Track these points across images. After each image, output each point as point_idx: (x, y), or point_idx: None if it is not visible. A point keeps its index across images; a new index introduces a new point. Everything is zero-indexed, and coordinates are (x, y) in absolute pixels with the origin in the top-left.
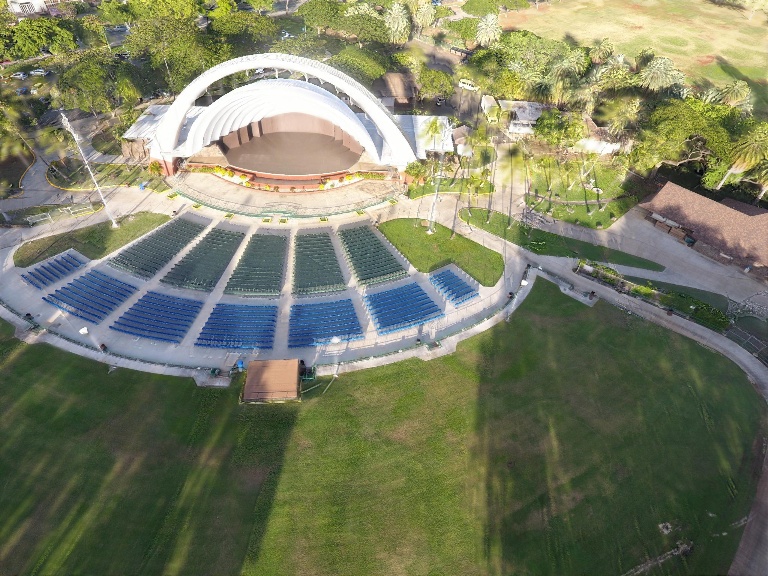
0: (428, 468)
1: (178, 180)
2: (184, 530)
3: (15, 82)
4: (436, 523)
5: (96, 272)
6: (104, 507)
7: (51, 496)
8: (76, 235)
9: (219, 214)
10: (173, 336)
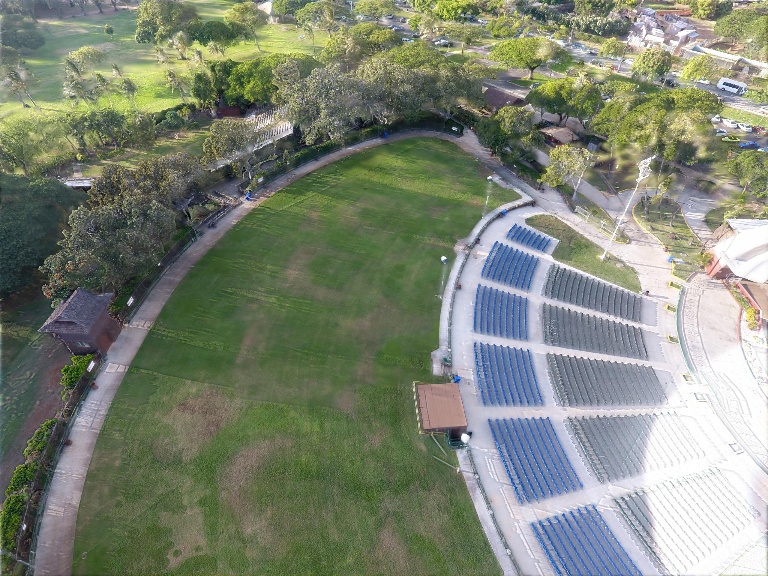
0: (348, 570)
1: (706, 284)
2: (309, 365)
3: (765, 137)
4: (289, 571)
5: (536, 261)
6: (330, 320)
7: (340, 293)
8: (578, 239)
9: (670, 330)
10: (480, 325)
